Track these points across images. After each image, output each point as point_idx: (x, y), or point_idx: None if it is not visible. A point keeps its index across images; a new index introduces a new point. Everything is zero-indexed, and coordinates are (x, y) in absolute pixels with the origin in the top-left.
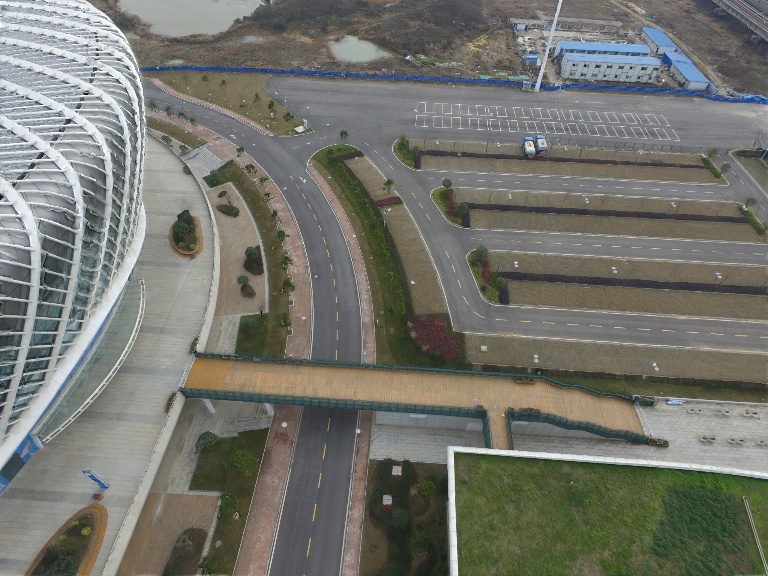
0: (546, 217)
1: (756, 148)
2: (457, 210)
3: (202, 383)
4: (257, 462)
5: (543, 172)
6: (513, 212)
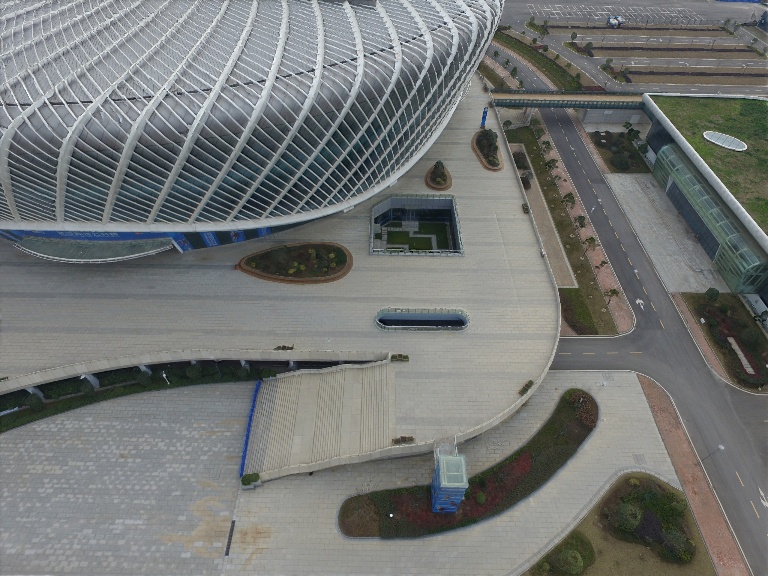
0: (636, 52)
1: (753, 20)
2: (586, 47)
3: None
4: (533, 135)
5: (625, 34)
6: (616, 50)
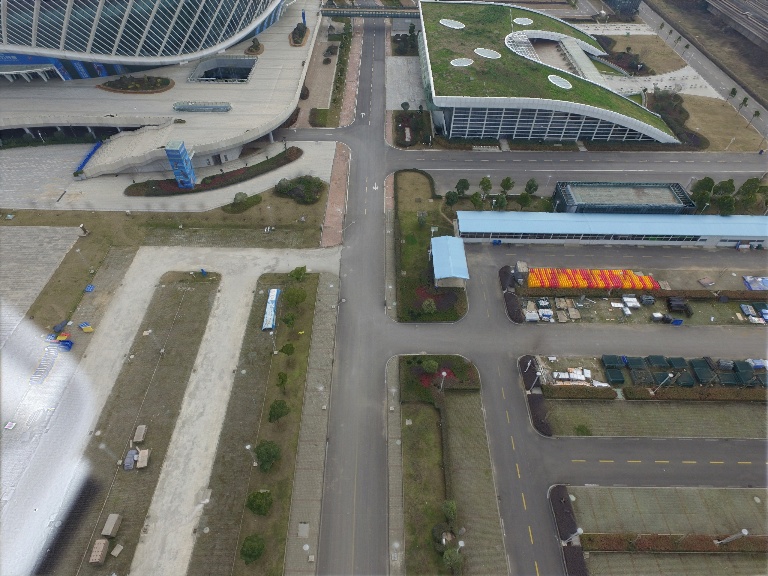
0: None
1: None
2: None
3: None
4: None
5: None
6: None
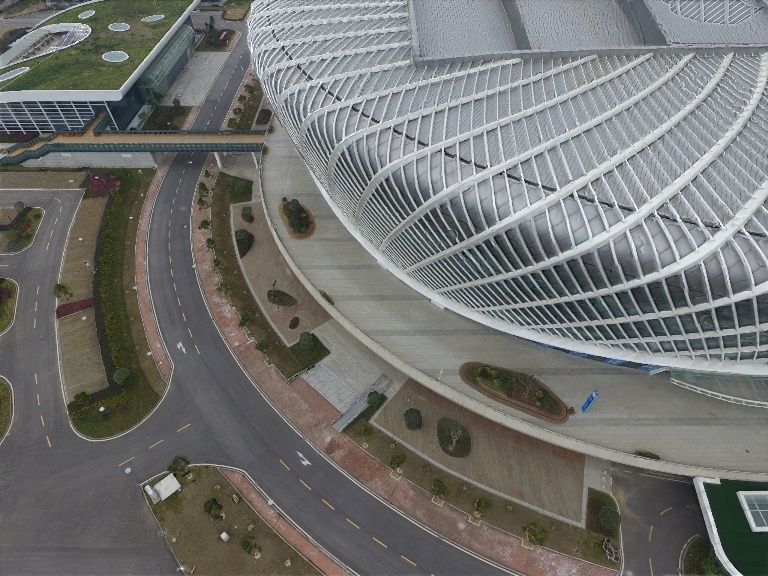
0: None
1: None
2: None
3: (257, 137)
4: None
5: None
6: None
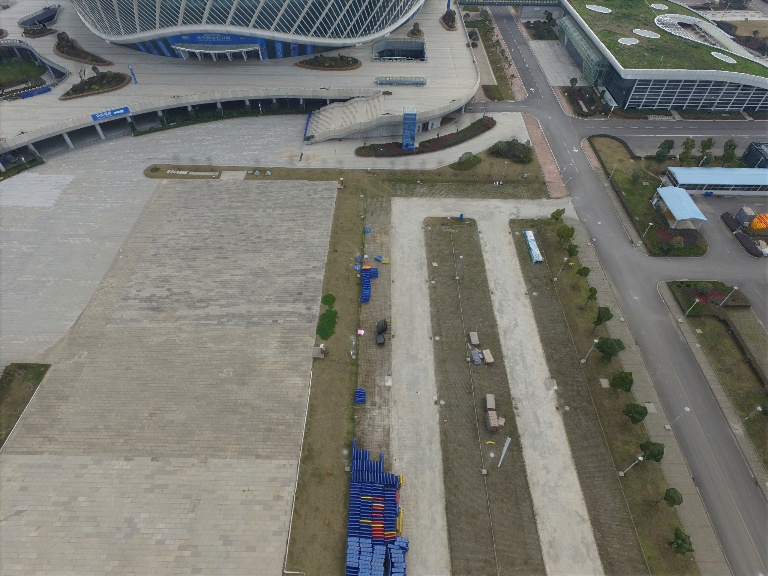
0: None
1: None
2: None
3: None
4: None
5: None
6: None
